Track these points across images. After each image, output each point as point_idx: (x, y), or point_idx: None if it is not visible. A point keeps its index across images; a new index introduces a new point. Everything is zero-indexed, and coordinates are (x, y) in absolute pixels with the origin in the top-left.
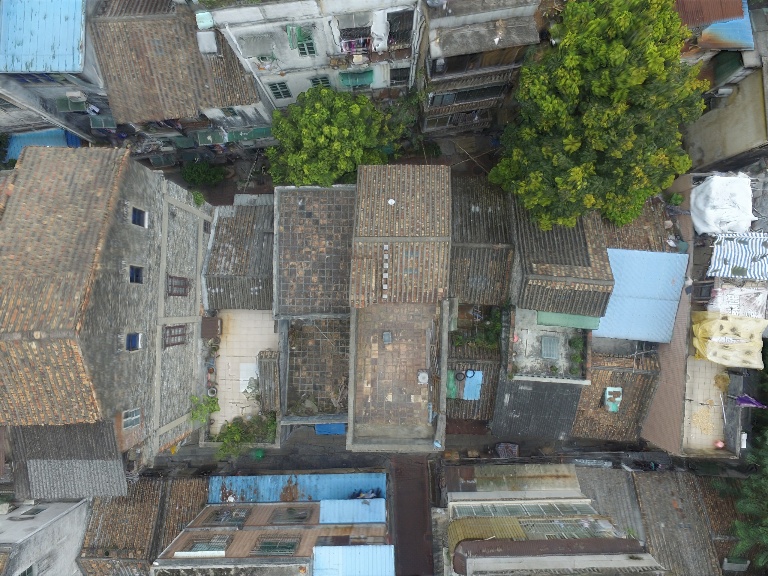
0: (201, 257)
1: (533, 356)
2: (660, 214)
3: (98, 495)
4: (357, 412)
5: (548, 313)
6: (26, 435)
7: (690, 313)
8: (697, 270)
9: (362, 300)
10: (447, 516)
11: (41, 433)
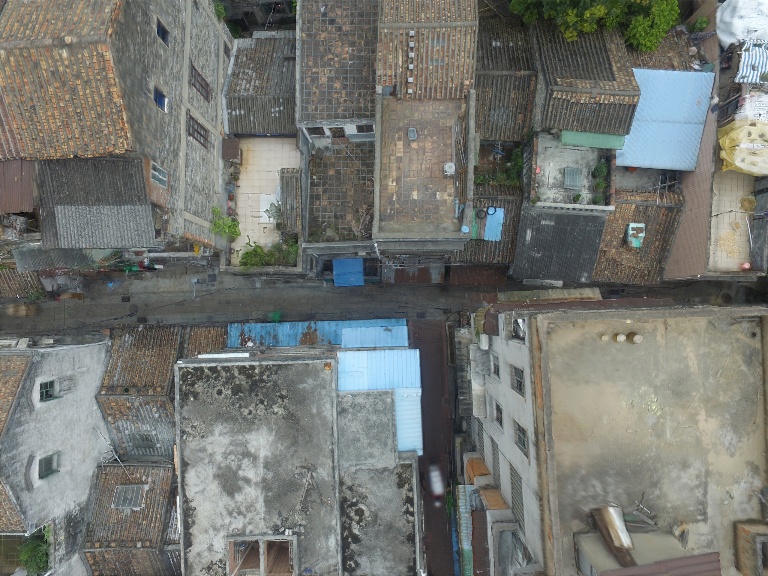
0: (222, 76)
1: (556, 188)
2: (684, 43)
3: (126, 245)
4: (382, 210)
5: (572, 133)
6: (54, 177)
7: (716, 131)
8: (722, 94)
9: (389, 75)
10: (471, 335)
11: (69, 176)
